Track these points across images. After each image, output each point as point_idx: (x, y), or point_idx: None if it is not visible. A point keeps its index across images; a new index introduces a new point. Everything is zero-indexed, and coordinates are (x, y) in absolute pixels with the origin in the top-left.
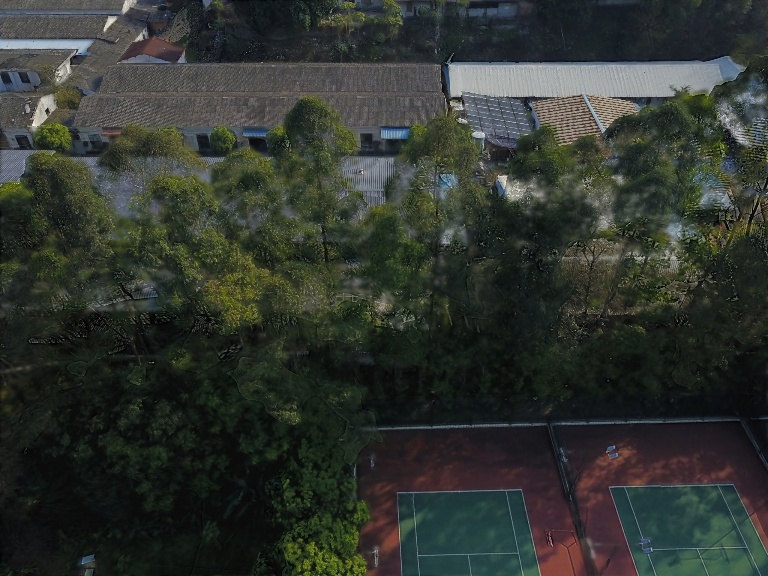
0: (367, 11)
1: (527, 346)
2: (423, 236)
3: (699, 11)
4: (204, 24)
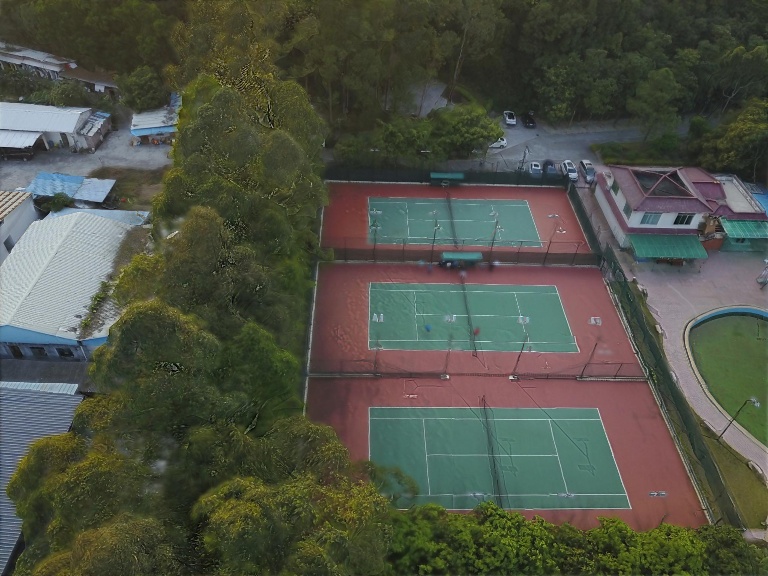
0: None
1: None
2: None
3: None
4: None
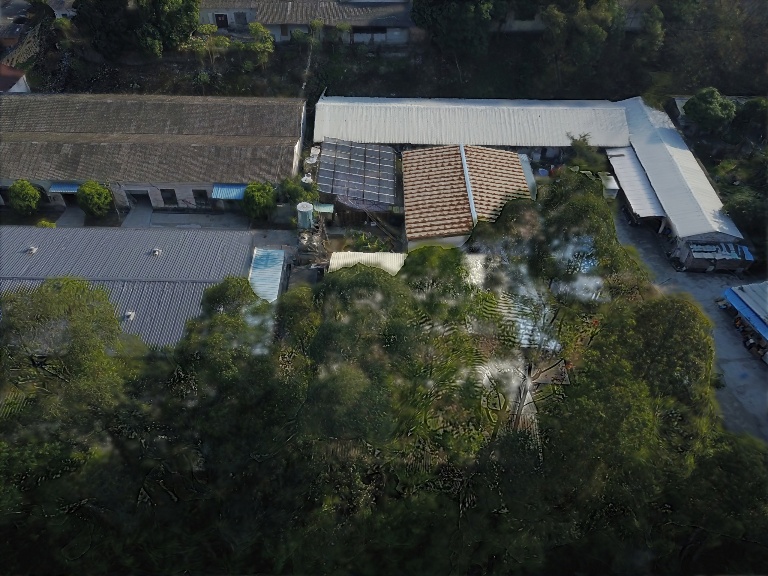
0: (242, 32)
1: (269, 532)
2: (56, 432)
3: (607, 45)
4: (51, 44)
